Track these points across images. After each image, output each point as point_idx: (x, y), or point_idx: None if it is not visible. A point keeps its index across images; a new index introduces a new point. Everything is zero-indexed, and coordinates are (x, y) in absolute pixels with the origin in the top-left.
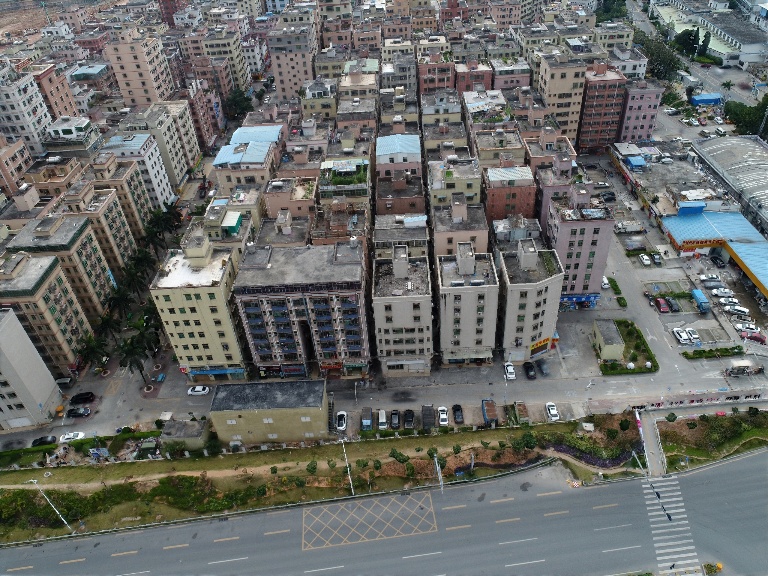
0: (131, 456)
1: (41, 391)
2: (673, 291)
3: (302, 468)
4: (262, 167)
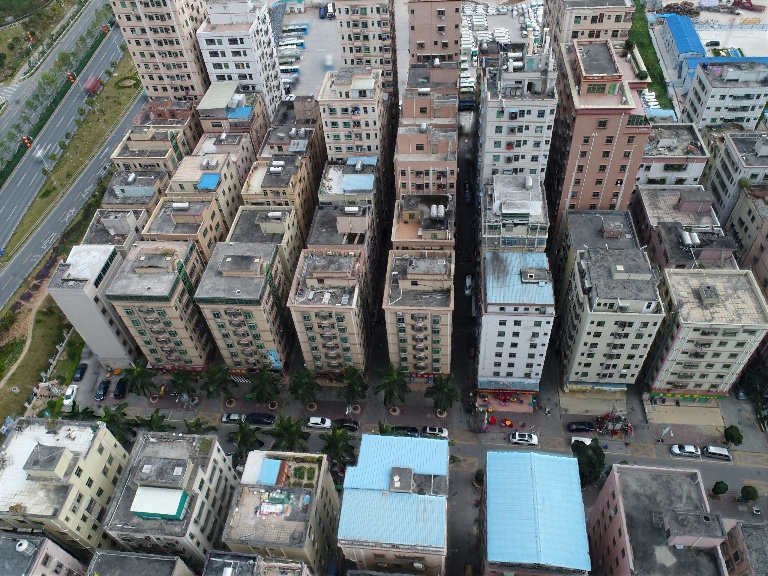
0: None
1: (103, 350)
2: None
3: None
4: None
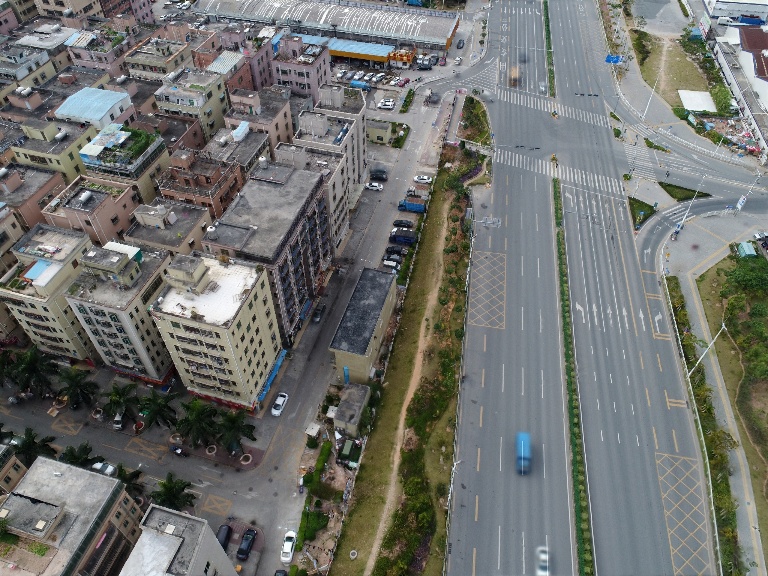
0: (357, 464)
1: None
2: None
3: (431, 317)
4: (7, 211)
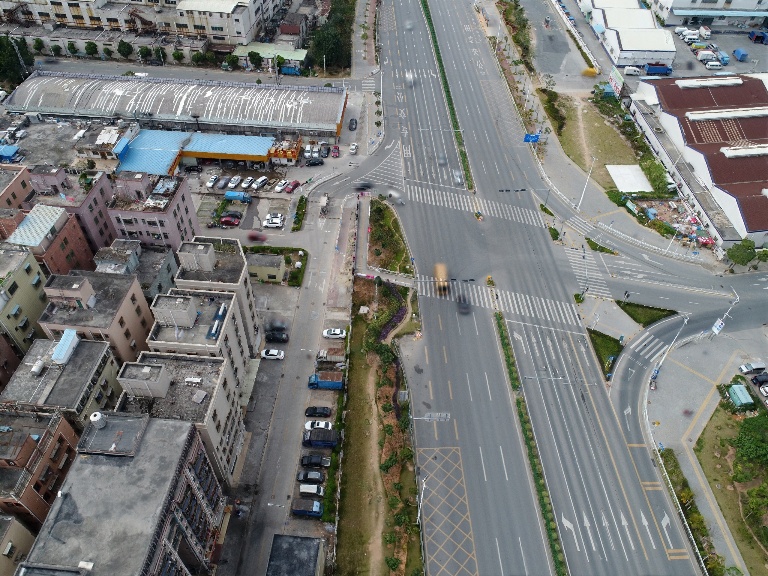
0: None
1: None
2: (214, 209)
3: None
4: None
